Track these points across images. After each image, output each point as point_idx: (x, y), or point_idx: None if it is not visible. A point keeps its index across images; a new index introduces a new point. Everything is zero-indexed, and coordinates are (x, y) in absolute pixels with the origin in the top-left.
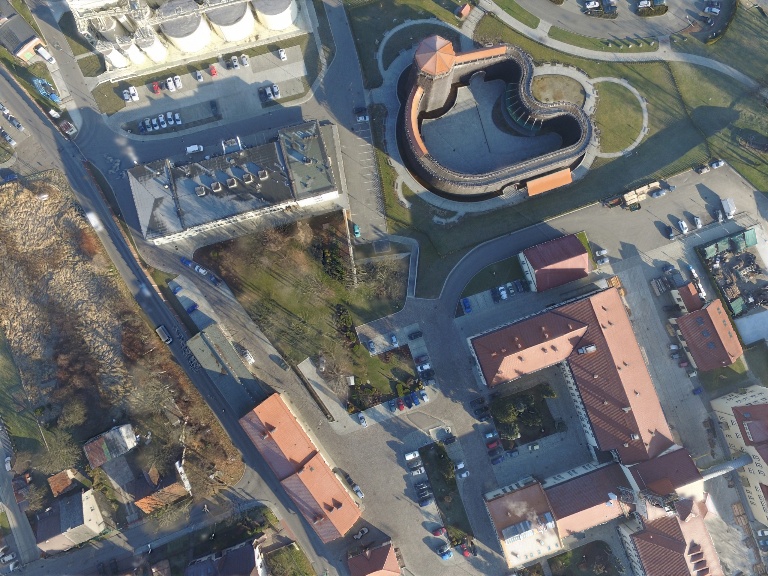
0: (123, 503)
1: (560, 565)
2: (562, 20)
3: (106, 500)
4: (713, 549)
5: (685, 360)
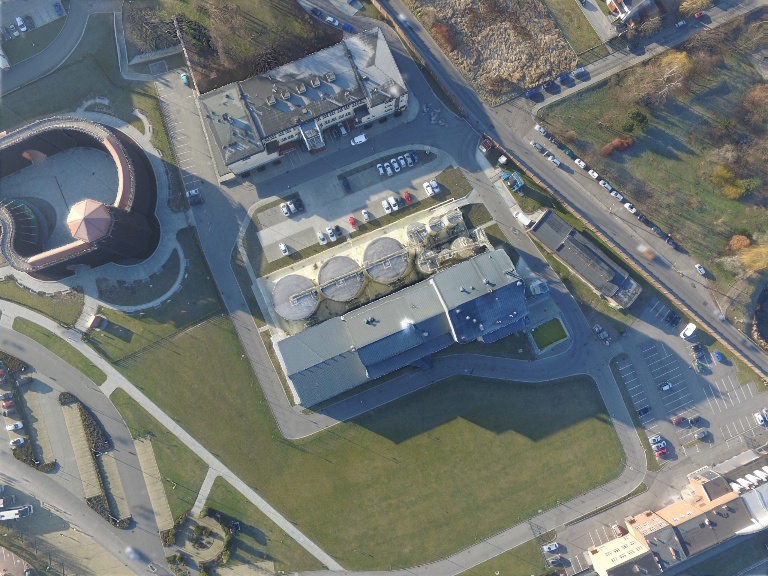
0: None
1: None
2: None
3: None
4: None
5: None
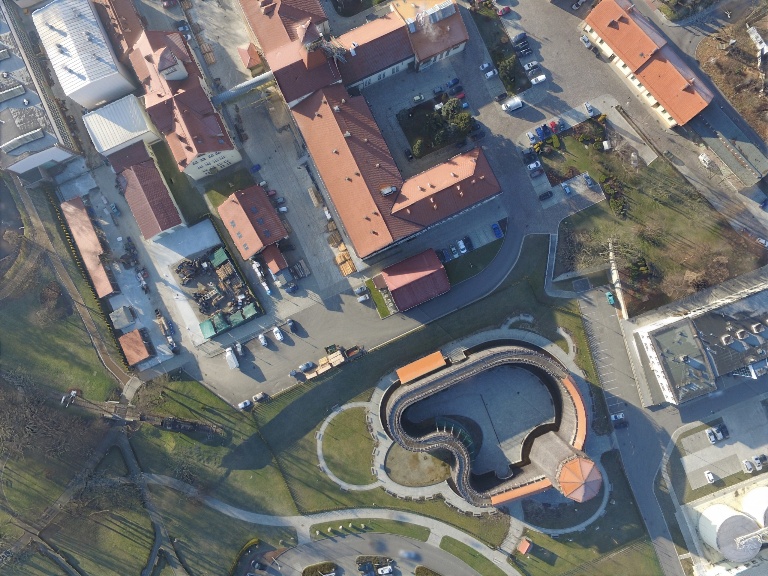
0: None
1: None
2: (415, 549)
3: None
4: (247, 13)
5: (271, 198)
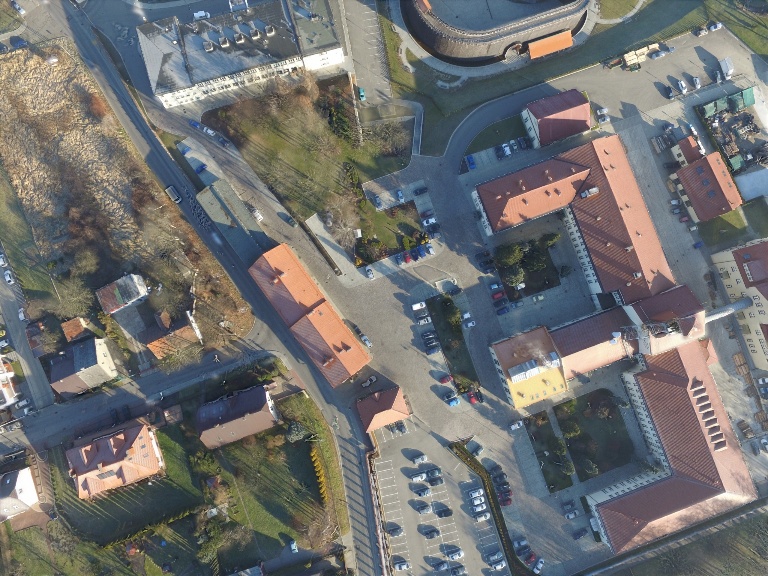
0: (135, 352)
1: (565, 410)
2: None
3: (118, 349)
4: (715, 388)
5: (686, 215)
